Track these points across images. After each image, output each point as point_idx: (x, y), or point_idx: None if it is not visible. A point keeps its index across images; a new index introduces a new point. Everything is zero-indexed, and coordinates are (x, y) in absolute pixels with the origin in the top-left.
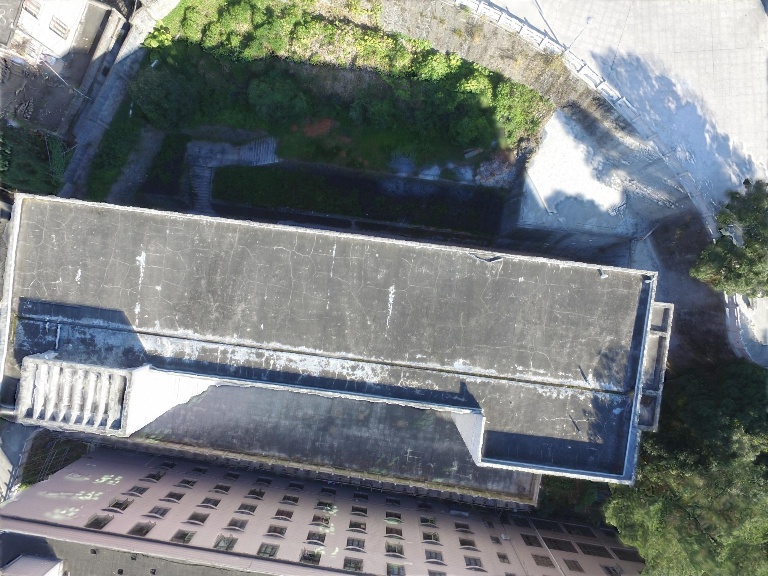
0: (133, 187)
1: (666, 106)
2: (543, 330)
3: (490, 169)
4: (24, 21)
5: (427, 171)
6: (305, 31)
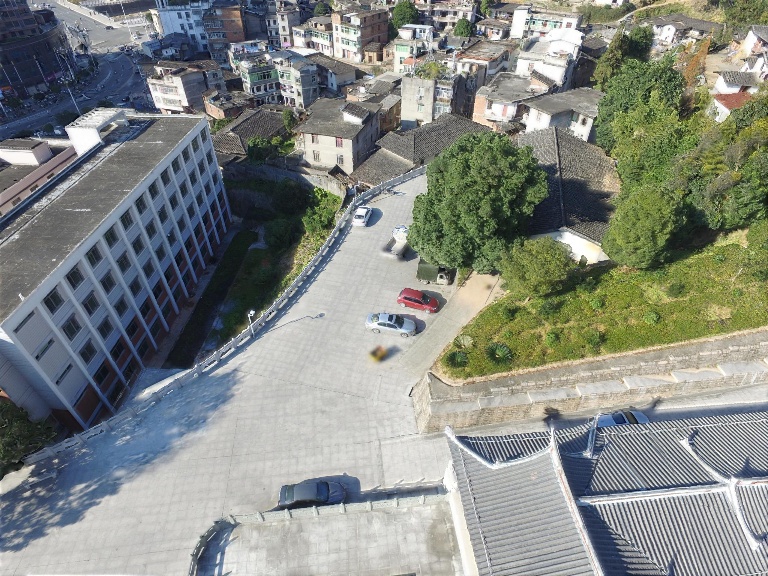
0: (252, 203)
1: (185, 415)
2: (7, 272)
3: (207, 356)
4: (308, 137)
5: (220, 322)
6: (317, 239)
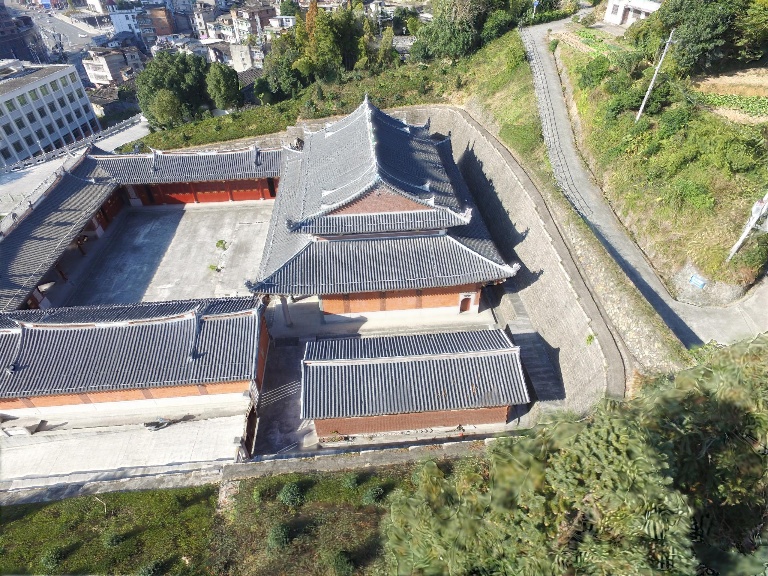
0: None
1: None
2: None
3: None
4: None
5: None
6: None
